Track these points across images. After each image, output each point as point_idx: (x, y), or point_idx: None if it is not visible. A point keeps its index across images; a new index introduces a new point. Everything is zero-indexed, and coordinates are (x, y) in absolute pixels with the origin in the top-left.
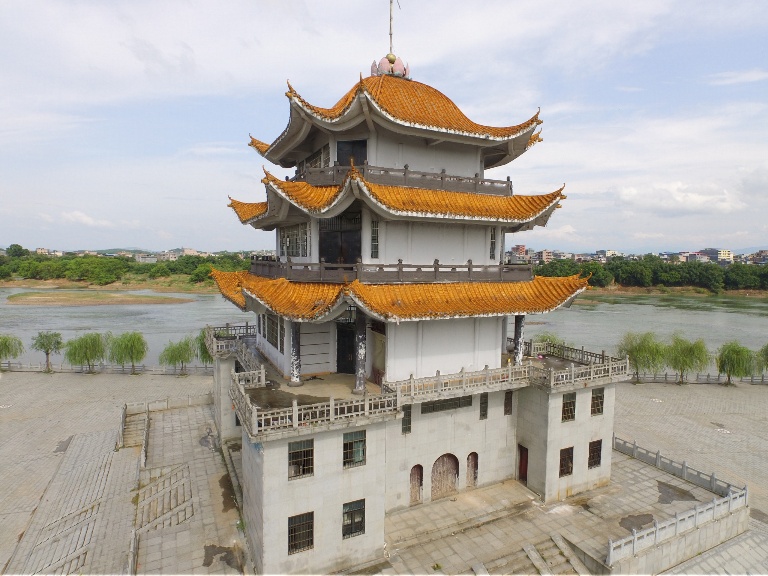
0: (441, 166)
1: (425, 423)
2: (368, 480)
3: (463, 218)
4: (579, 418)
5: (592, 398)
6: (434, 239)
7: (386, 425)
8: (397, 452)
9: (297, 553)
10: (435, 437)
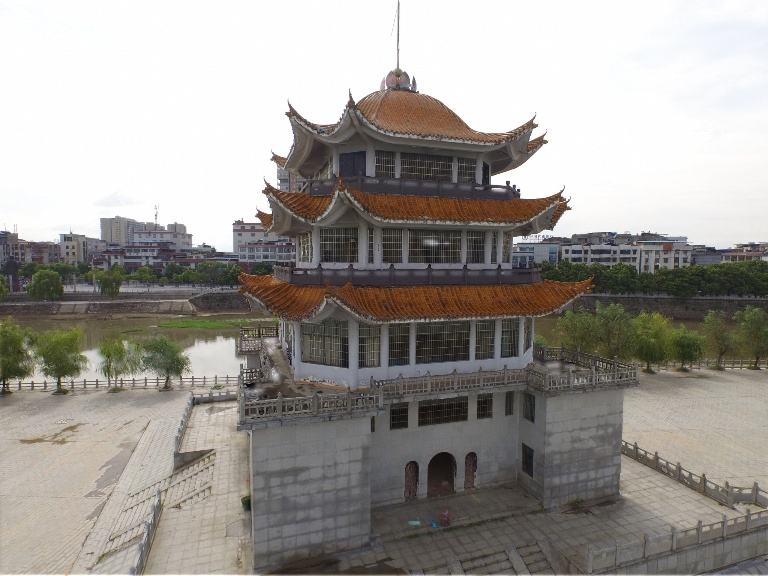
0: None
1: None
2: None
3: None
4: None
5: None
6: None
7: None
8: None
9: None
10: None
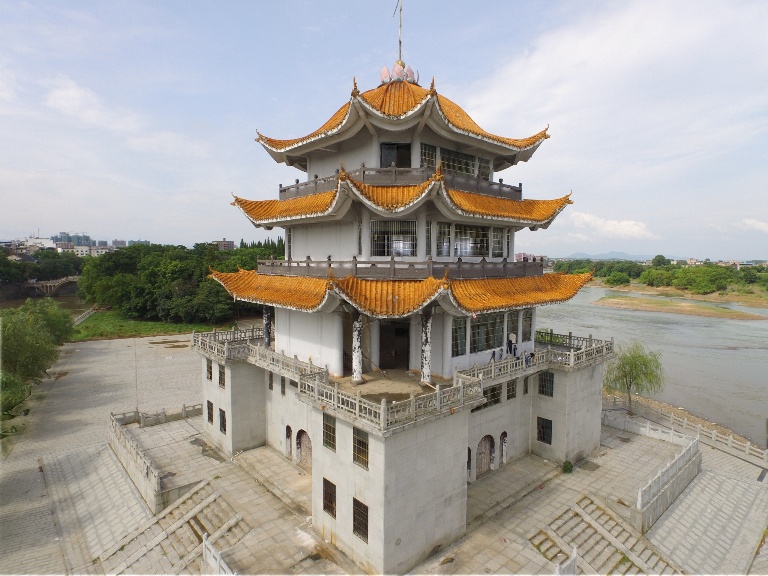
0: (345, 168)
1: (292, 394)
2: None
3: (287, 219)
4: (340, 454)
5: (354, 438)
6: None
7: None
8: None
9: None
10: (297, 410)
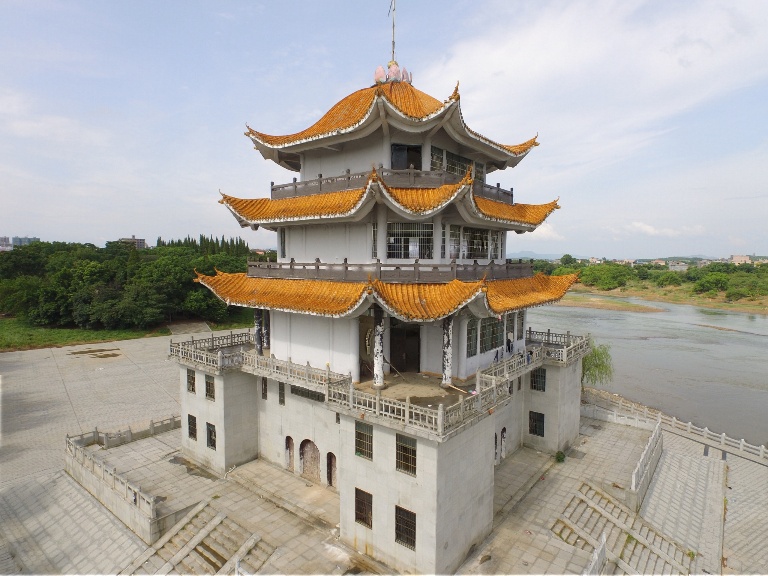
0: (349, 167)
1: (294, 402)
2: (216, 414)
3: (293, 220)
4: (379, 462)
5: (397, 445)
6: (322, 240)
7: (270, 391)
8: (277, 417)
9: (191, 439)
10: (301, 419)
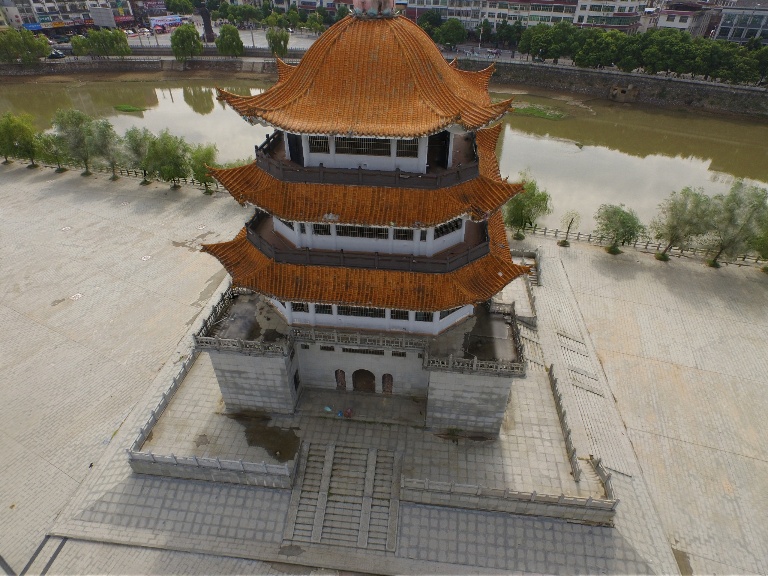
0: None
1: None
2: None
3: None
4: None
5: None
6: None
7: None
8: None
9: None
10: None
